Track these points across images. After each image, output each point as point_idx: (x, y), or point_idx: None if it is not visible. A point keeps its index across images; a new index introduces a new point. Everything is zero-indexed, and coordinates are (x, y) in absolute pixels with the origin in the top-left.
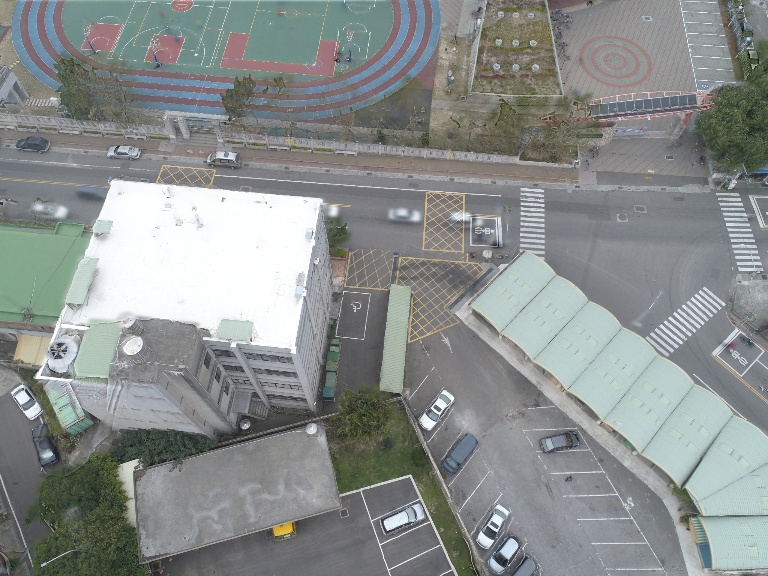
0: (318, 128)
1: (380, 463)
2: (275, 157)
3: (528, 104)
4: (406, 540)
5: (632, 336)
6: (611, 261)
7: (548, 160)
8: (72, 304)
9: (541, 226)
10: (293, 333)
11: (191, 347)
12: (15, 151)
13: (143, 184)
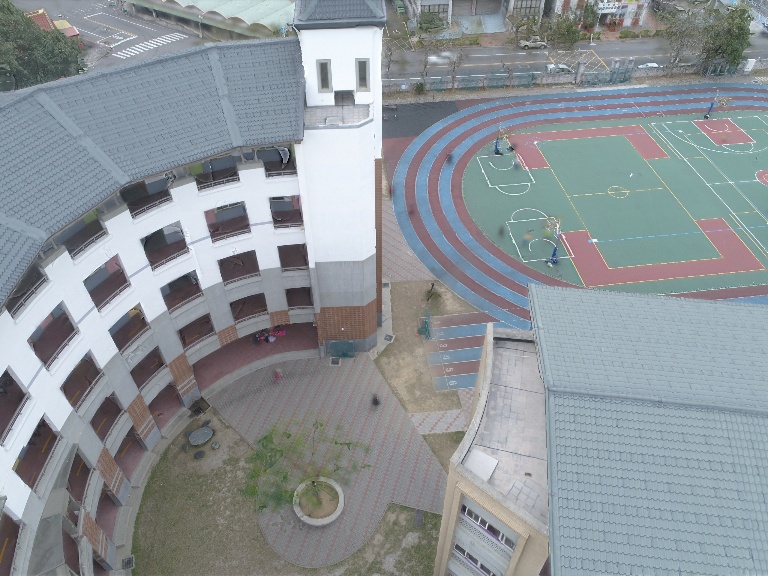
0: (489, 95)
1: None
2: None
3: None
4: None
5: (200, 6)
6: None
7: None
8: None
9: None
10: None
11: None
12: None
13: None
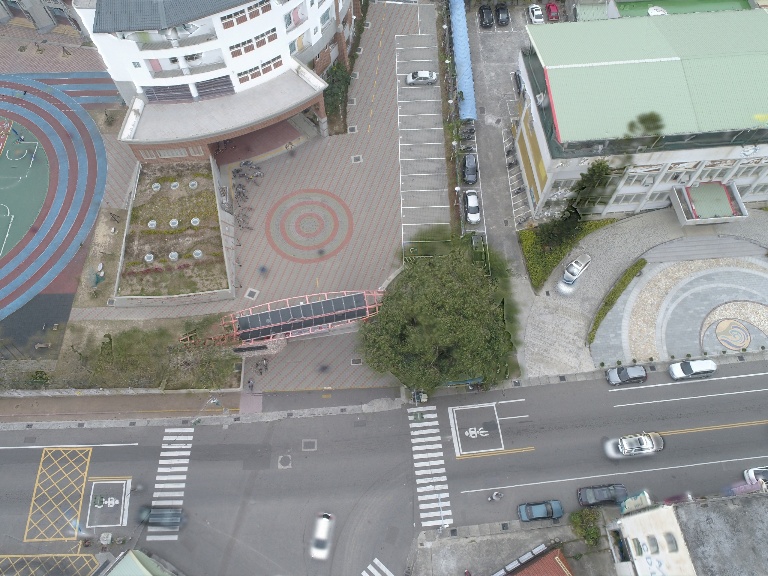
0: None
1: None
2: None
3: (190, 302)
4: None
5: None
6: (261, 532)
7: (202, 385)
8: None
9: (180, 487)
10: None
11: None
12: None
13: None
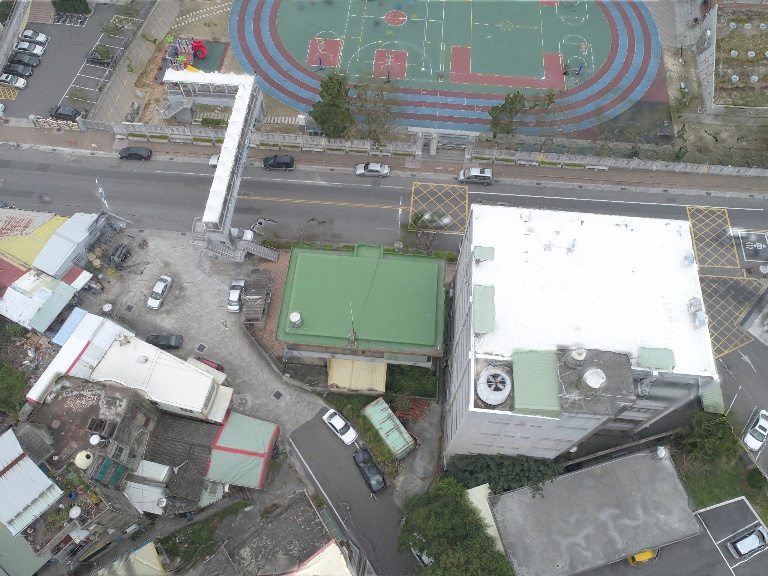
0: (565, 143)
1: (709, 485)
2: (525, 173)
3: None
4: (755, 563)
5: None
6: None
7: None
8: (478, 333)
9: None
10: (708, 360)
11: (631, 377)
12: (261, 169)
13: (503, 208)
